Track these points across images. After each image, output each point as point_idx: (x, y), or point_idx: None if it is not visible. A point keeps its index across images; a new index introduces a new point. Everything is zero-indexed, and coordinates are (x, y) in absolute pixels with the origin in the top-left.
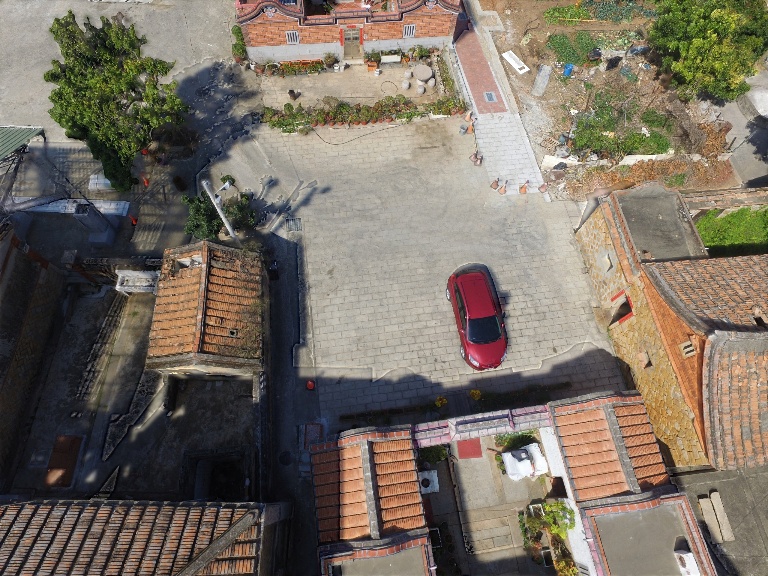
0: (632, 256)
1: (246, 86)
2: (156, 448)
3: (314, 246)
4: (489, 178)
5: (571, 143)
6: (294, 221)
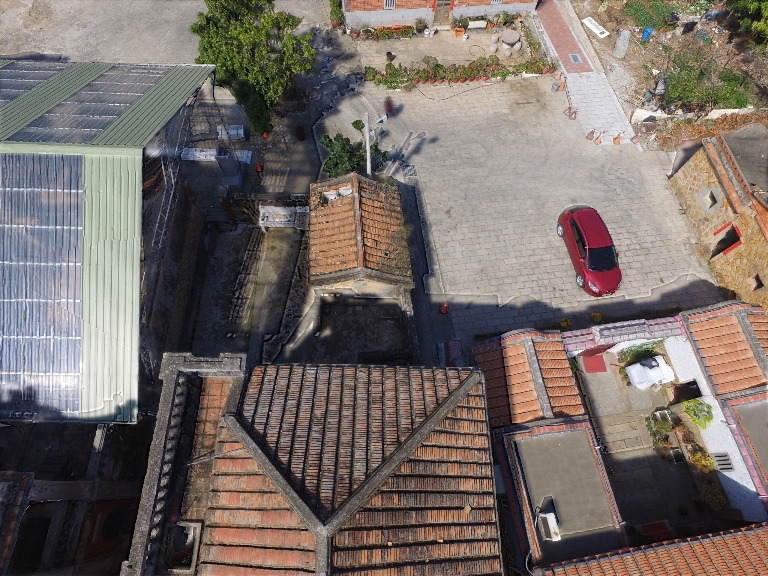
0: (742, 188)
1: (344, 49)
2: None
3: (430, 189)
4: (584, 130)
5: (658, 99)
6: (409, 167)
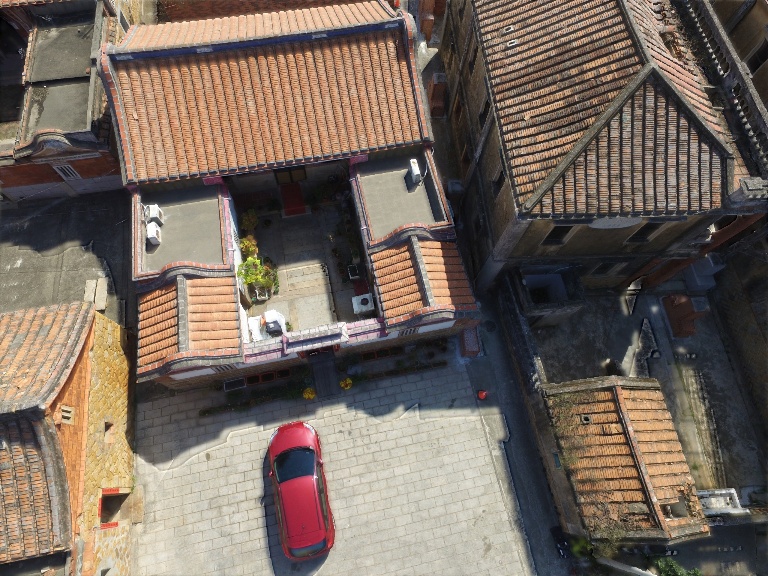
0: (75, 572)
1: None
2: (607, 330)
3: None
4: None
5: None
6: None
